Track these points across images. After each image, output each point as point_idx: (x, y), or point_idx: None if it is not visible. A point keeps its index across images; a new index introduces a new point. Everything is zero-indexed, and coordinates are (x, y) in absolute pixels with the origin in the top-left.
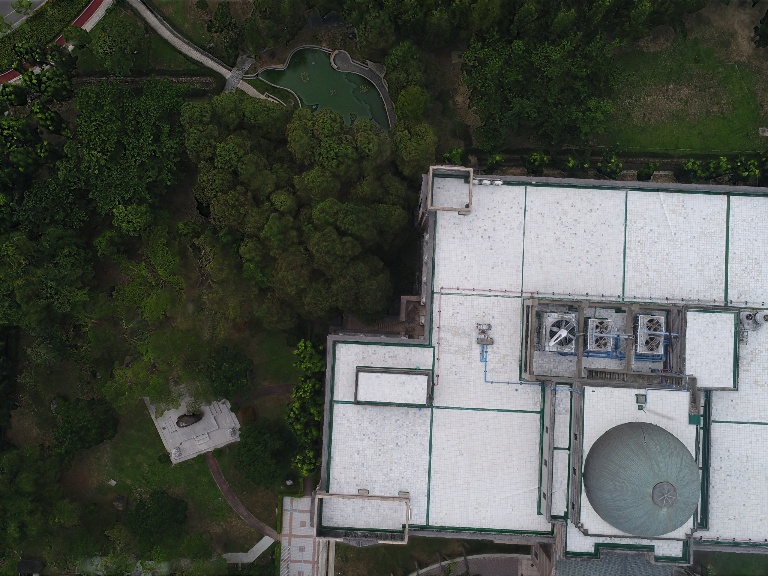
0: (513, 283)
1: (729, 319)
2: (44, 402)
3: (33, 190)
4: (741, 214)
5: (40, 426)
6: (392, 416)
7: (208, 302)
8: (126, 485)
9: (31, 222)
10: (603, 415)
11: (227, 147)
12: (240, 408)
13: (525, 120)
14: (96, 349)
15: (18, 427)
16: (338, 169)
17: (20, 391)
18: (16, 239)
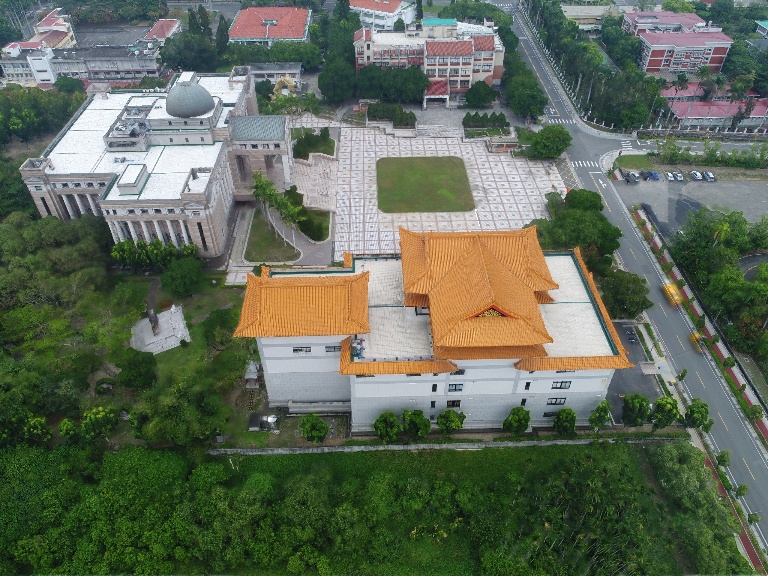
0: (97, 155)
1: (135, 98)
2: (120, 427)
3: None
4: (95, 107)
5: None
6: (151, 184)
7: (68, 299)
8: None
9: None
10: (161, 115)
11: None
12: None
13: (24, 194)
14: None
15: None
16: (7, 237)
17: (106, 446)
18: None
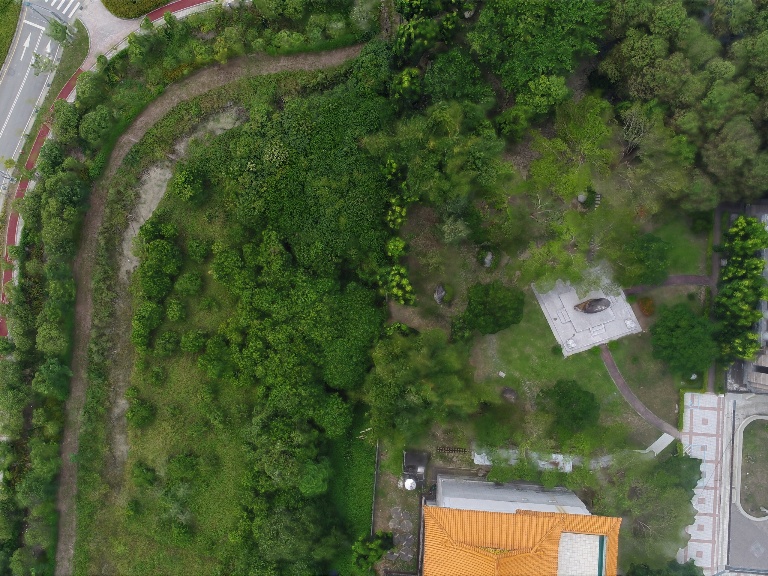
0: None
1: None
2: (426, 291)
3: (438, 64)
4: None
5: (422, 316)
6: None
7: (634, 178)
8: (514, 378)
9: (444, 95)
10: None
11: (670, 9)
12: (636, 299)
13: None
14: (515, 226)
15: (399, 317)
16: None
17: None
18: (447, 106)
